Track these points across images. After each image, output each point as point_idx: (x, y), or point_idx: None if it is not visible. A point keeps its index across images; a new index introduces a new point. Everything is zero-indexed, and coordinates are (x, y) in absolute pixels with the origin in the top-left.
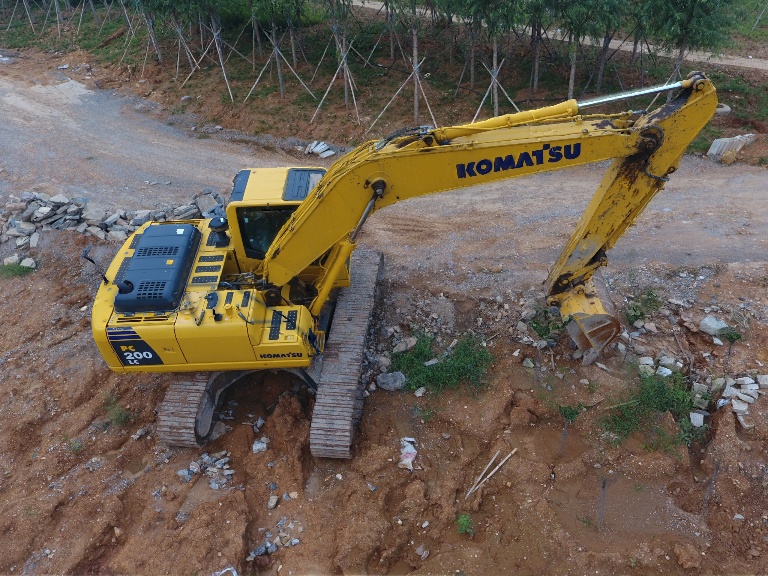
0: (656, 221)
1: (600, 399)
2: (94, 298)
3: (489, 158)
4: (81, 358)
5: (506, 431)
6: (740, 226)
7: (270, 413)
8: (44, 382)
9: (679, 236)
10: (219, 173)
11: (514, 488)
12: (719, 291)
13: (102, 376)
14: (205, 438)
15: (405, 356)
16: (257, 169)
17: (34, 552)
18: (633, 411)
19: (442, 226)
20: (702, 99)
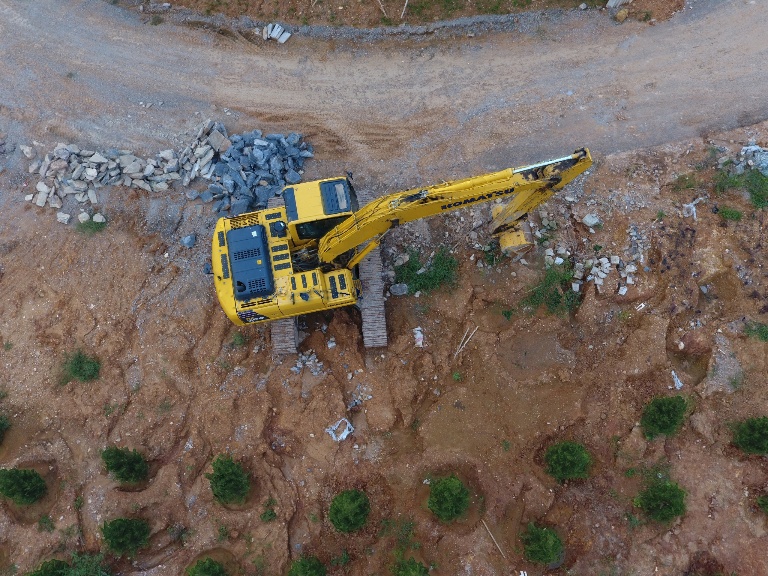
0: (561, 110)
1: (523, 286)
2: (169, 245)
3: (461, 201)
4: (190, 300)
5: (471, 314)
6: (619, 110)
7: (329, 319)
8: (175, 322)
9: (576, 127)
10: (198, 79)
11: (479, 349)
12: (597, 185)
13: (211, 311)
14: None
15: (404, 271)
16: (297, 185)
17: (236, 428)
18: (541, 292)
19: (404, 133)
20: (584, 163)
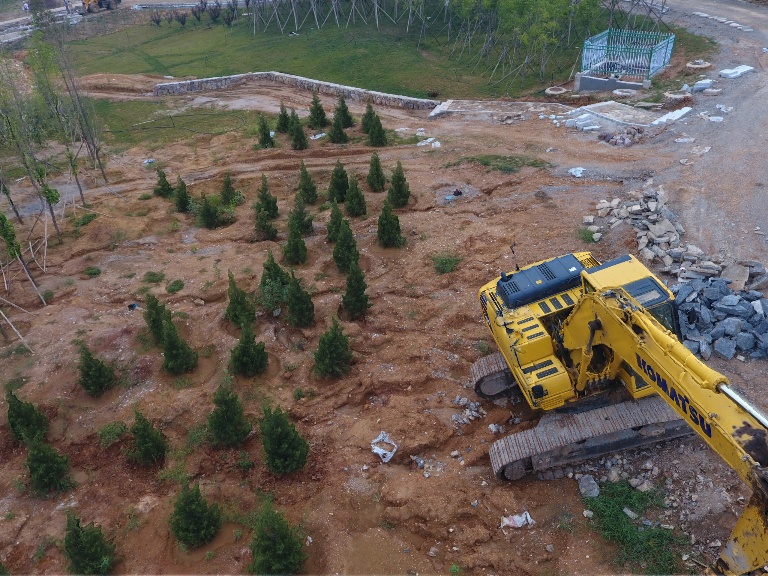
0: None
1: None
2: None
3: None
4: None
5: None
6: None
7: None
8: None
9: None
10: None
11: None
12: None
13: None
14: (490, 397)
15: (620, 486)
16: (637, 261)
17: (391, 363)
18: None
19: None
20: None
